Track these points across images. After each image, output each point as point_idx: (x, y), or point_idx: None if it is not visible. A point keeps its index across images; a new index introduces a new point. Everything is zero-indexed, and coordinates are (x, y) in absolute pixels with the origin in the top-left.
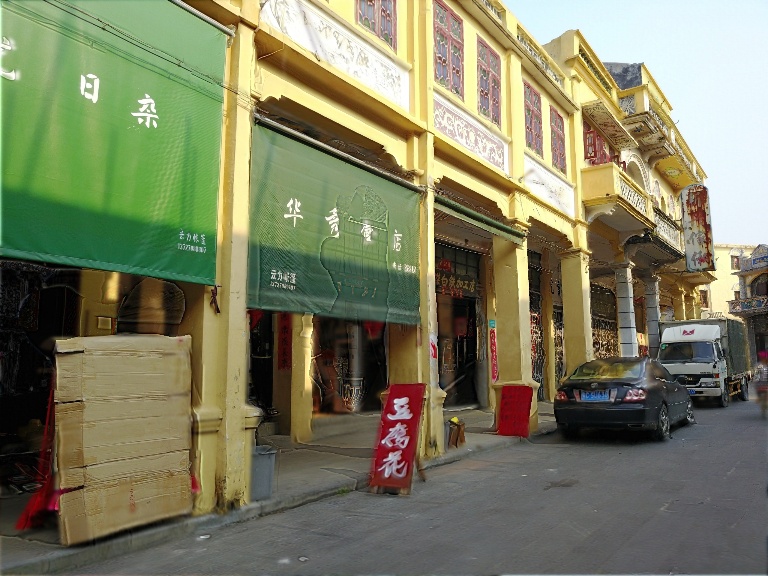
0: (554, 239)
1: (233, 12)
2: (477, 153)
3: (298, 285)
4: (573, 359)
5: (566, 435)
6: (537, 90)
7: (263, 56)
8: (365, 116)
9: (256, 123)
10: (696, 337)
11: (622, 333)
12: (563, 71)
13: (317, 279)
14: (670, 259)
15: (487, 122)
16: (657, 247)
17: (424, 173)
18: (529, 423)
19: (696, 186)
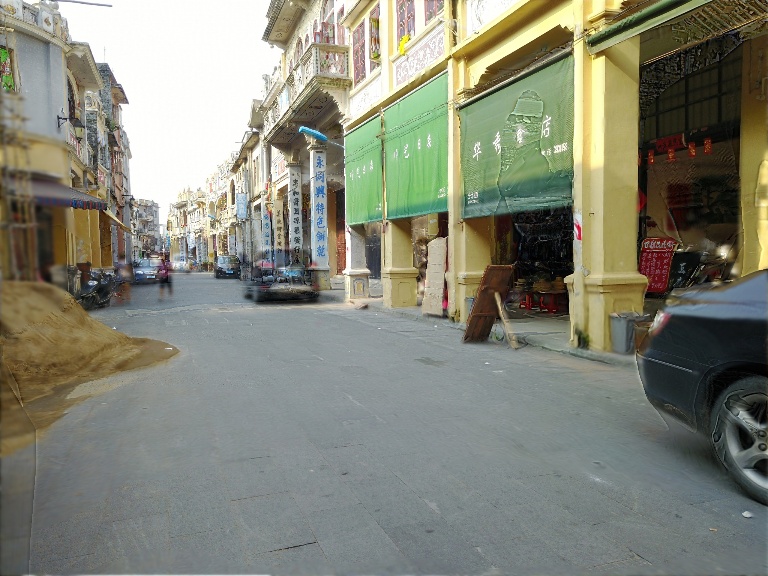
0: None
1: (444, 60)
2: None
3: (479, 198)
4: None
5: None
6: None
7: (466, 60)
8: (537, 18)
9: (460, 110)
10: None
11: None
12: None
13: (489, 190)
14: None
15: None
16: None
17: None
18: None
19: None
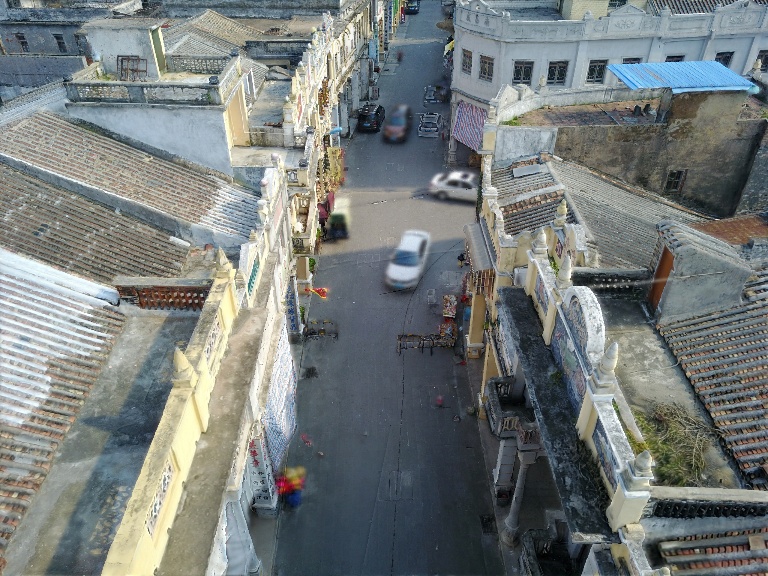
0: None
1: None
2: None
3: None
4: None
5: (408, 14)
6: None
7: None
8: None
9: None
10: None
11: None
12: None
13: None
14: None
15: None
16: None
17: None
18: None
19: None
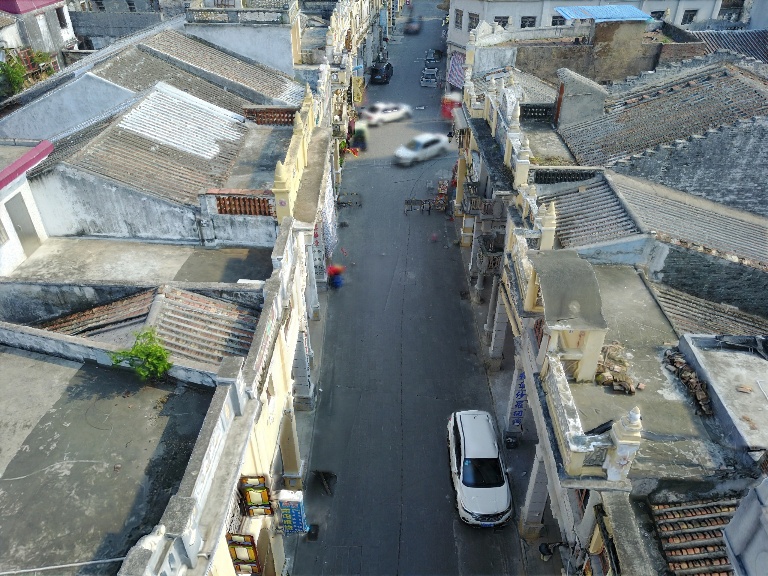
0: None
1: None
2: None
3: None
4: None
5: None
6: None
7: None
8: None
9: None
10: None
11: None
12: None
13: None
14: None
15: None
16: None
17: None
18: None
19: None
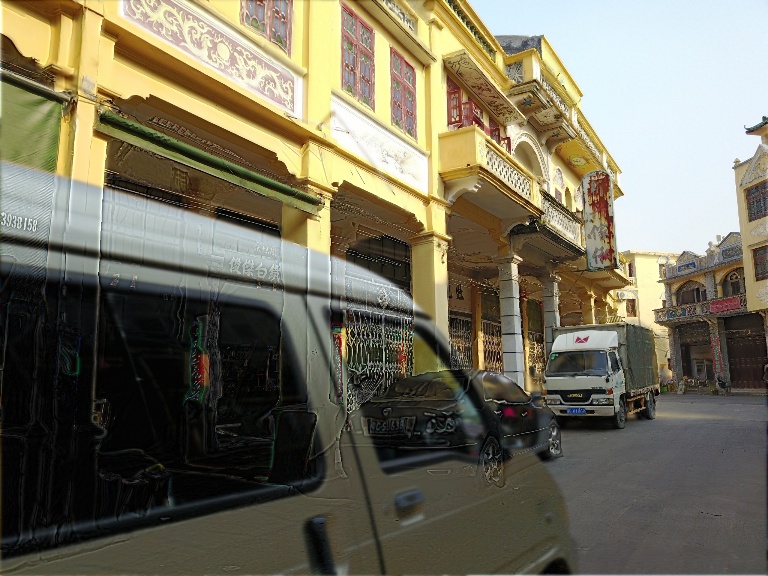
0: (400, 219)
1: None
2: (233, 76)
3: None
4: (422, 372)
5: (353, 484)
6: (367, 22)
7: None
8: None
9: None
10: (589, 345)
11: (505, 340)
12: (421, 15)
13: None
14: (570, 256)
15: (257, 37)
16: (548, 239)
17: (74, 73)
18: (315, 464)
19: (598, 173)
